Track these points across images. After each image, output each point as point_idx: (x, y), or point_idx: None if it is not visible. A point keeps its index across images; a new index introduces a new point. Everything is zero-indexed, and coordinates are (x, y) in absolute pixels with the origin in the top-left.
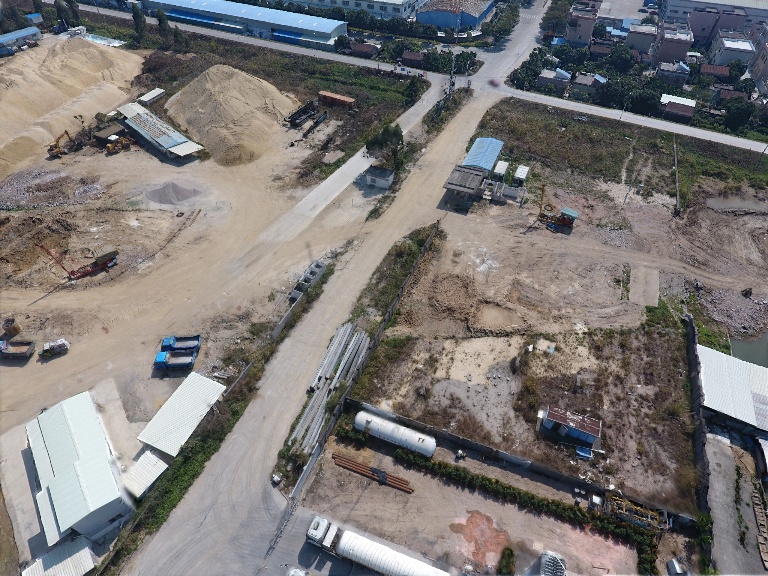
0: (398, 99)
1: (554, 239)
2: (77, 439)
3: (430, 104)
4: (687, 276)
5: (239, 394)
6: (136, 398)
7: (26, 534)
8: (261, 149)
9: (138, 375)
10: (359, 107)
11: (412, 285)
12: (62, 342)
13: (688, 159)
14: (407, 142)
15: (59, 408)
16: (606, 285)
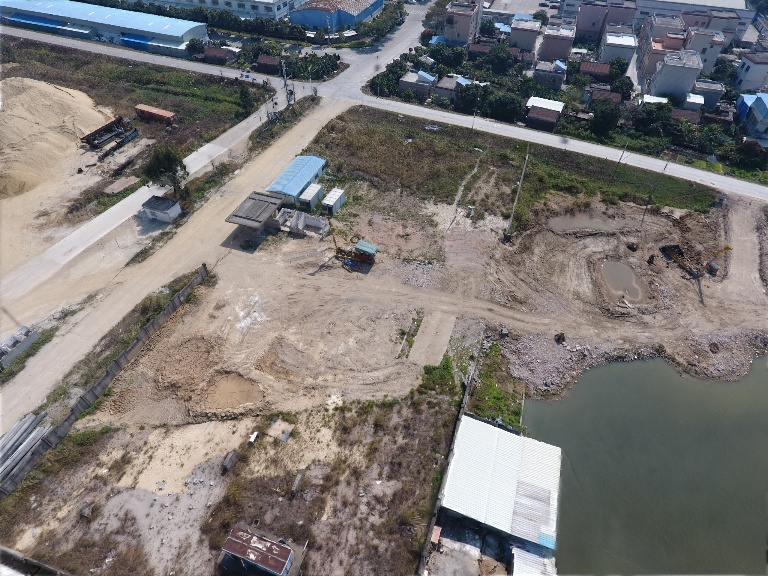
0: (231, 111)
1: (346, 280)
2: None
3: None
4: (490, 321)
5: None
6: None
7: None
8: (39, 178)
9: None
10: (181, 122)
11: (144, 352)
12: None
13: (536, 172)
14: (221, 163)
15: None
16: (387, 339)
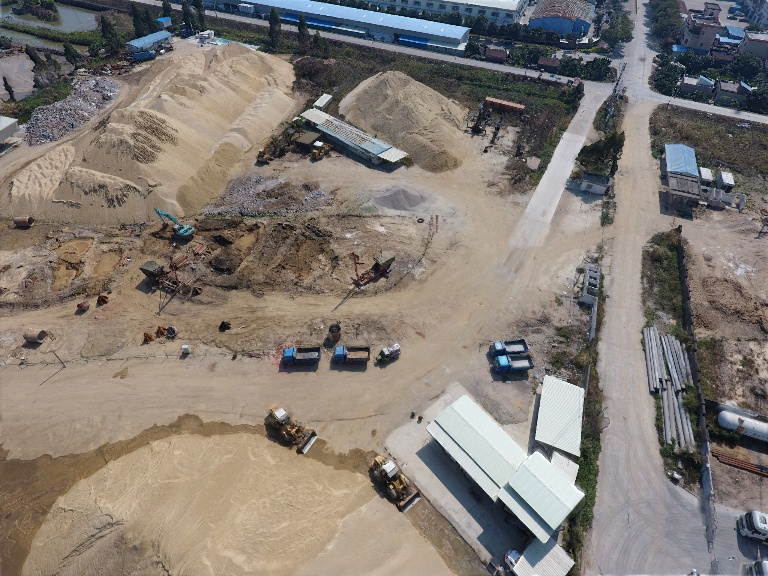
0: (560, 105)
1: None
2: (490, 441)
3: (592, 110)
4: None
5: (595, 396)
6: (492, 401)
7: (472, 533)
8: (458, 155)
9: (480, 378)
10: (527, 113)
11: None
12: (399, 347)
13: None
14: None
15: (452, 411)
16: None
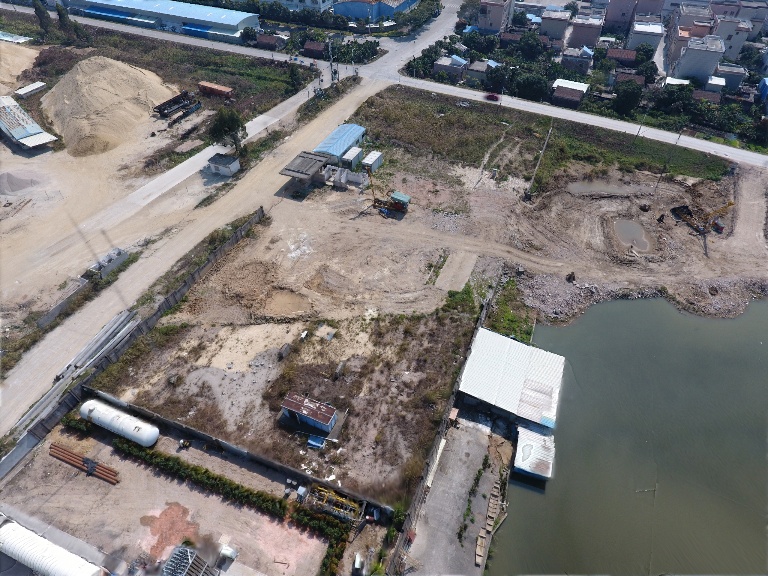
0: (281, 88)
1: (382, 224)
2: None
3: (313, 93)
4: (508, 260)
5: None
6: None
7: None
8: (119, 139)
9: None
10: (238, 97)
11: (213, 272)
12: None
13: (558, 143)
14: (273, 130)
15: None
16: (416, 270)
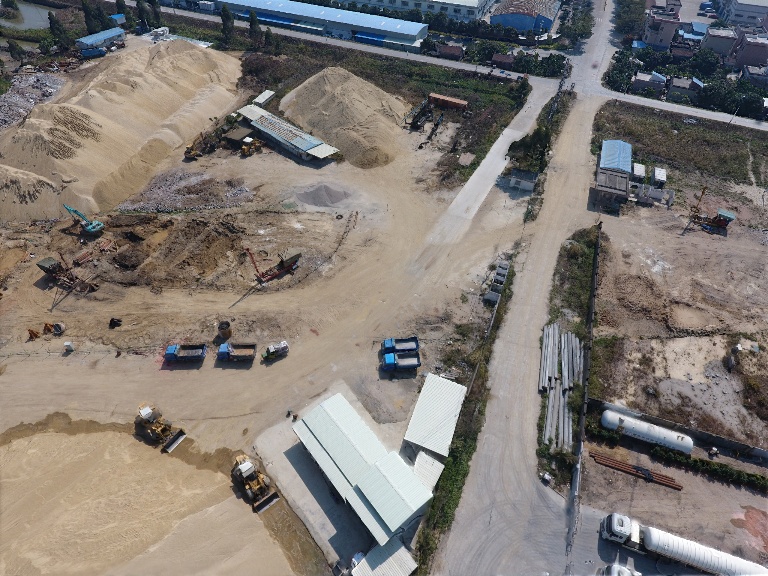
0: (506, 101)
1: (713, 240)
2: (353, 440)
3: (538, 107)
4: None
5: (479, 394)
6: (374, 399)
7: (324, 535)
8: (392, 151)
9: (366, 377)
10: (471, 109)
11: None
12: (285, 344)
13: None
14: None
15: (321, 410)
16: None
